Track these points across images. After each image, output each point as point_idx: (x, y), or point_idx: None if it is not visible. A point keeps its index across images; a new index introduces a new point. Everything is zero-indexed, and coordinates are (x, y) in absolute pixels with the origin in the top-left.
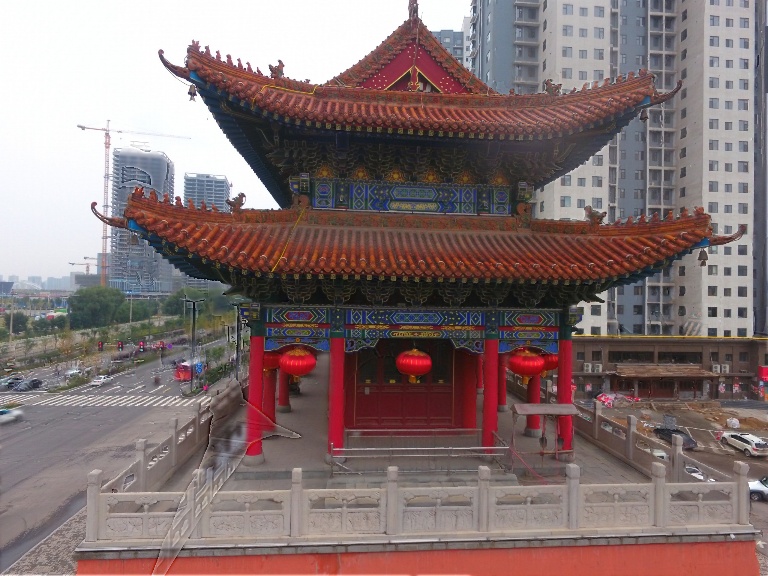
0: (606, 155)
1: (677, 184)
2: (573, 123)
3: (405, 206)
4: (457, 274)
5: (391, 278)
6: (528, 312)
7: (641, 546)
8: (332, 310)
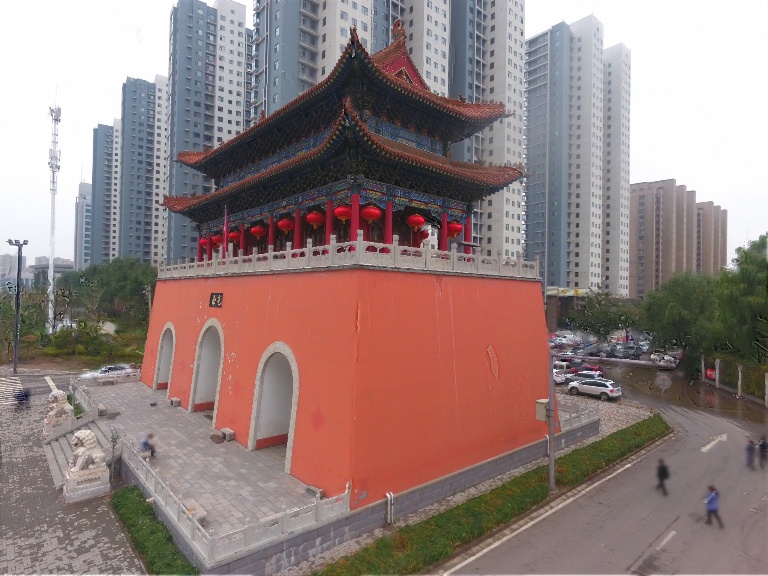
0: None
1: None
2: (481, 117)
3: (404, 141)
4: (455, 172)
5: (433, 169)
6: (457, 203)
7: (517, 281)
8: (388, 187)
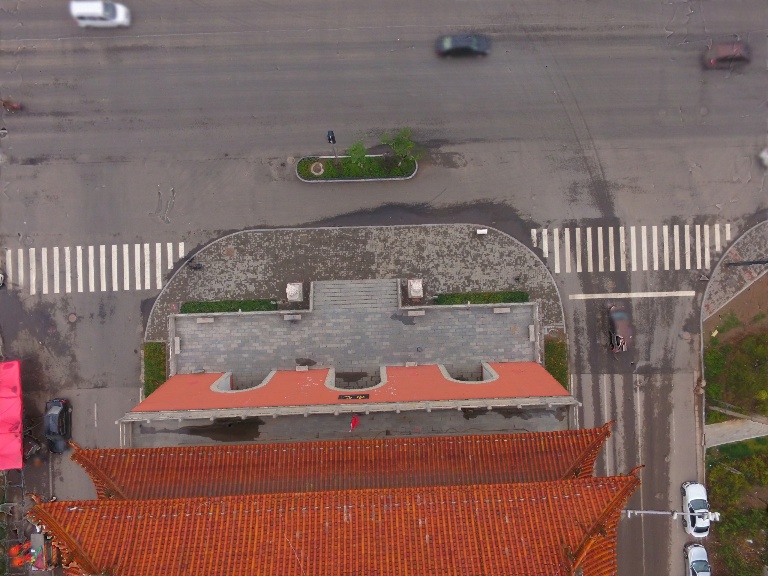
0: None
1: None
2: None
3: None
4: None
5: None
6: None
7: None
8: None
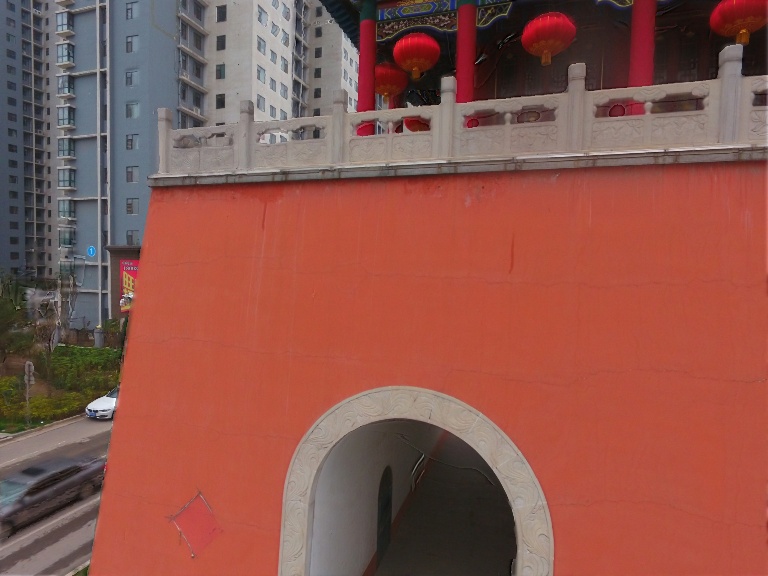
0: (292, 36)
1: (310, 104)
2: None
3: None
4: None
5: None
6: None
7: None
8: None
